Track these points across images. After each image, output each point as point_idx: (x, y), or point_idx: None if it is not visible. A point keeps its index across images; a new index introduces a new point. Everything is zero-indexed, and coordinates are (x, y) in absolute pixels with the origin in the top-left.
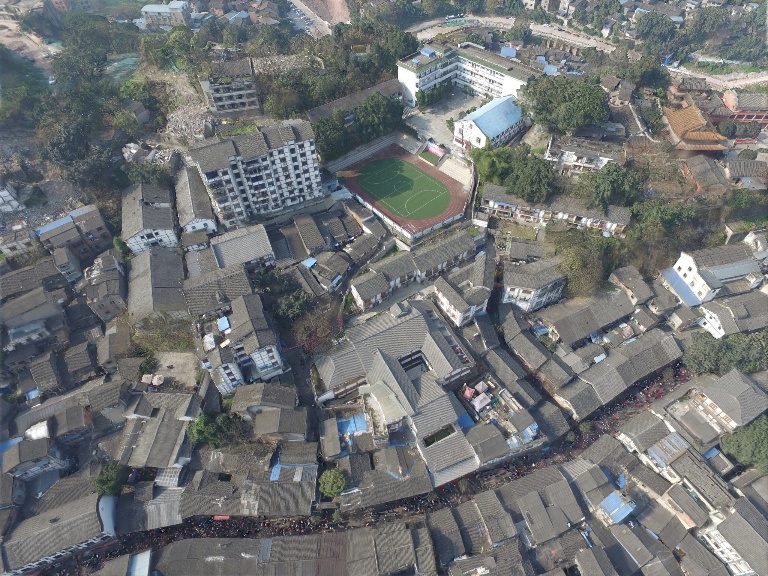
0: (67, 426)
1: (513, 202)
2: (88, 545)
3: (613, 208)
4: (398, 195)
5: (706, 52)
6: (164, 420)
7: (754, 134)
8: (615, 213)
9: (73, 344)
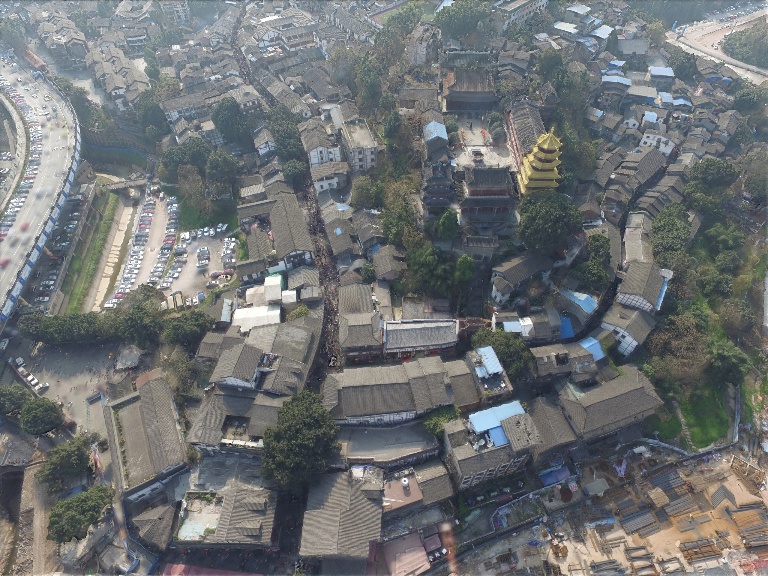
0: None
1: None
2: None
3: None
4: None
5: None
6: None
7: None
8: None
9: None
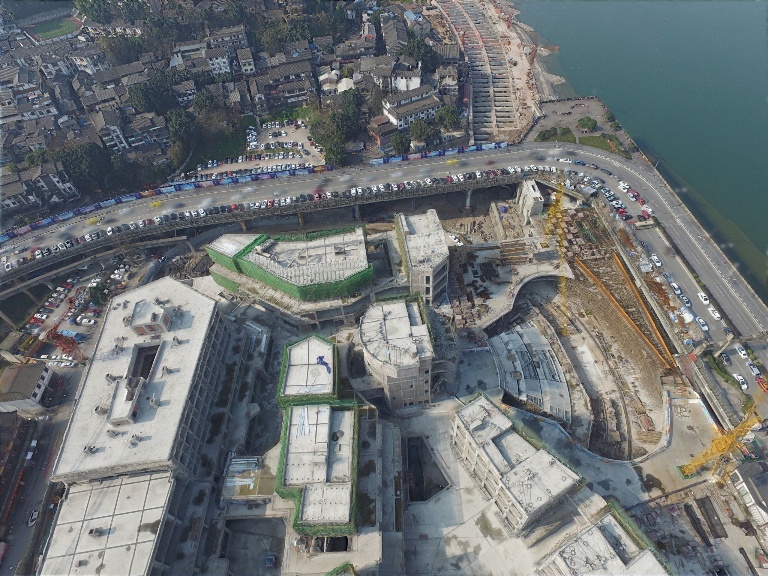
0: None
1: (95, 25)
2: None
3: (136, 21)
4: (49, 31)
5: None
6: None
7: None
8: (137, 24)
9: None
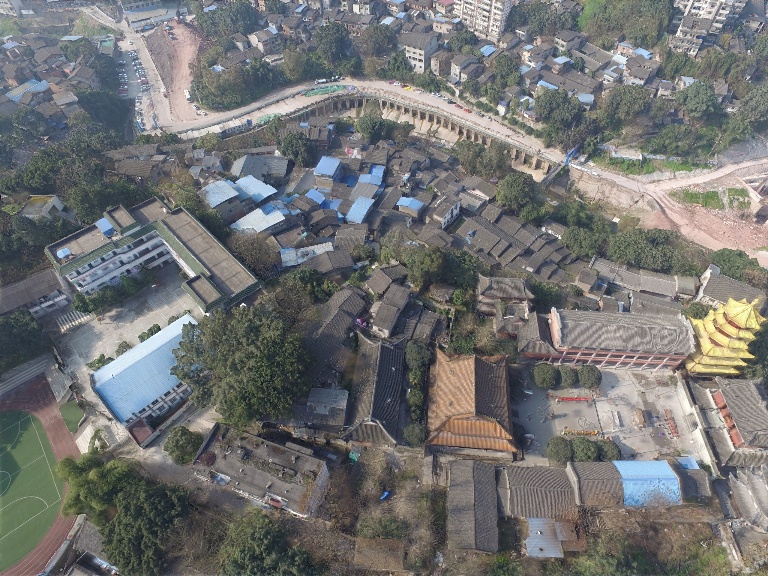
0: None
1: None
2: None
3: None
4: None
5: (623, 142)
6: None
7: (589, 388)
8: None
9: None
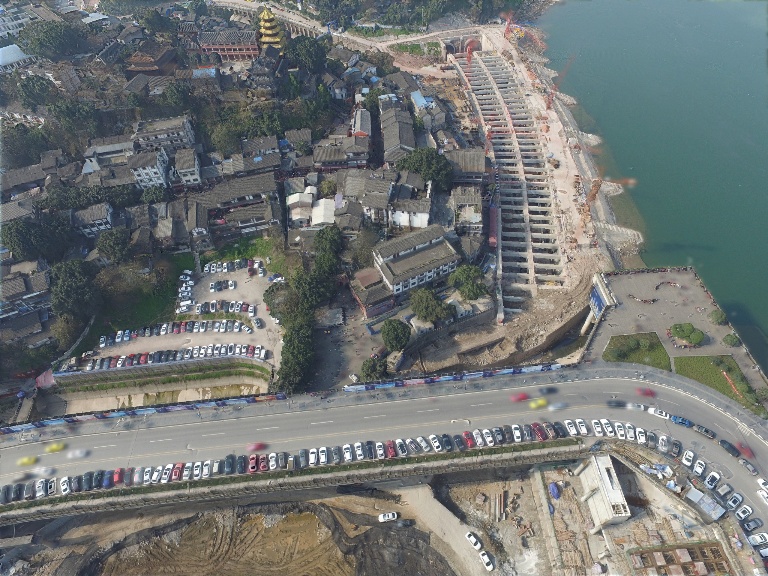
0: None
1: None
2: None
3: (39, 107)
4: None
5: (368, 19)
6: None
7: (214, 62)
8: (40, 110)
9: None
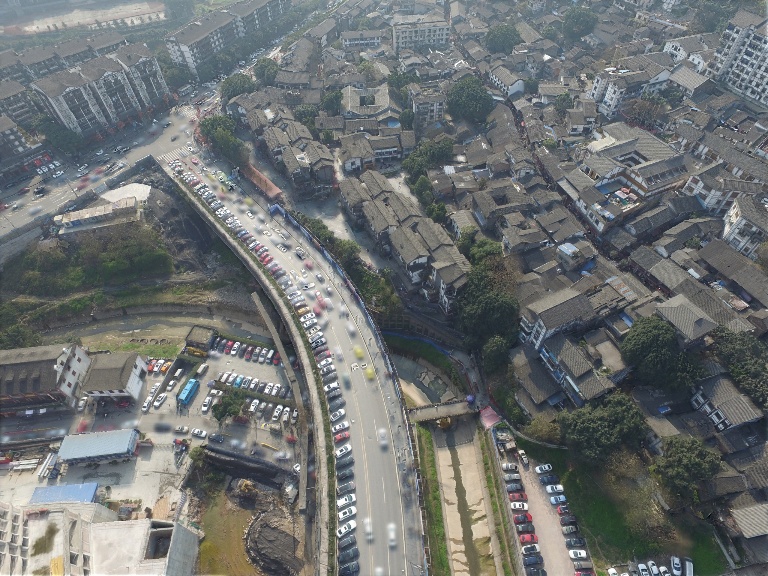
0: (551, 64)
1: None
2: (503, 91)
3: None
4: None
5: None
6: (564, 88)
7: None
8: None
9: (593, 57)
